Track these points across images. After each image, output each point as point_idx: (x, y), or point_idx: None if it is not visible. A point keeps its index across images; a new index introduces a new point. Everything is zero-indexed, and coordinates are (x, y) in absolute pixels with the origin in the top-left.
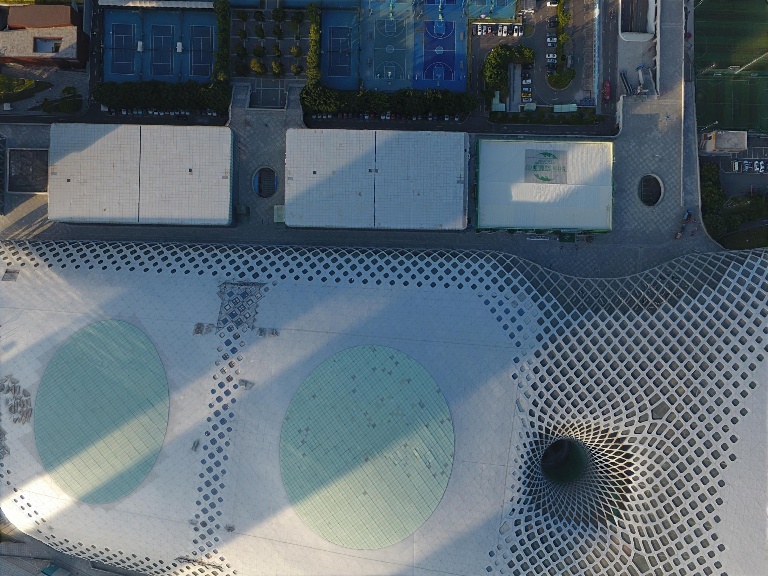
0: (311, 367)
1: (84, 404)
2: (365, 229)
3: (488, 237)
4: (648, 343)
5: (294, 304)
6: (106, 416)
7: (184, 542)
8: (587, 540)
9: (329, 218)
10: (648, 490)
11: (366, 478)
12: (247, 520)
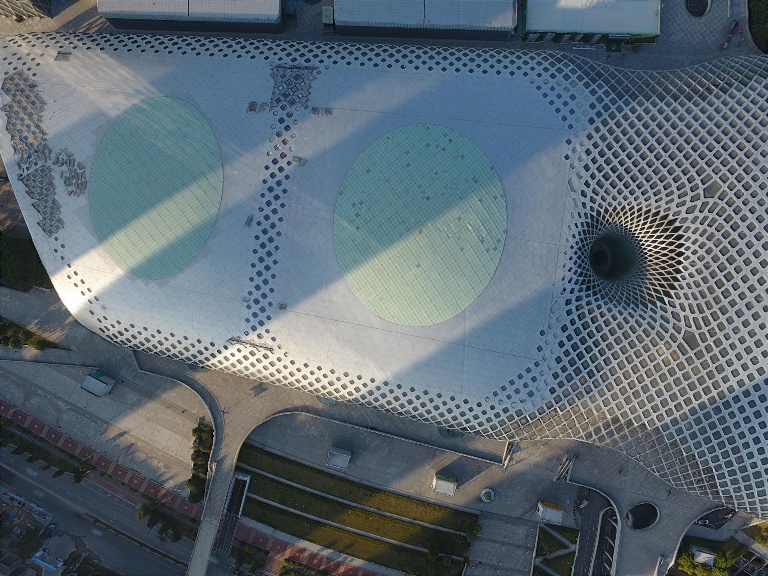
0: (365, 144)
1: (139, 176)
2: (413, 33)
3: (535, 46)
4: (700, 126)
5: (347, 86)
6: (161, 188)
7: (236, 321)
8: (637, 320)
9: (379, 14)
10: (699, 268)
11: (420, 250)
12: (300, 297)
